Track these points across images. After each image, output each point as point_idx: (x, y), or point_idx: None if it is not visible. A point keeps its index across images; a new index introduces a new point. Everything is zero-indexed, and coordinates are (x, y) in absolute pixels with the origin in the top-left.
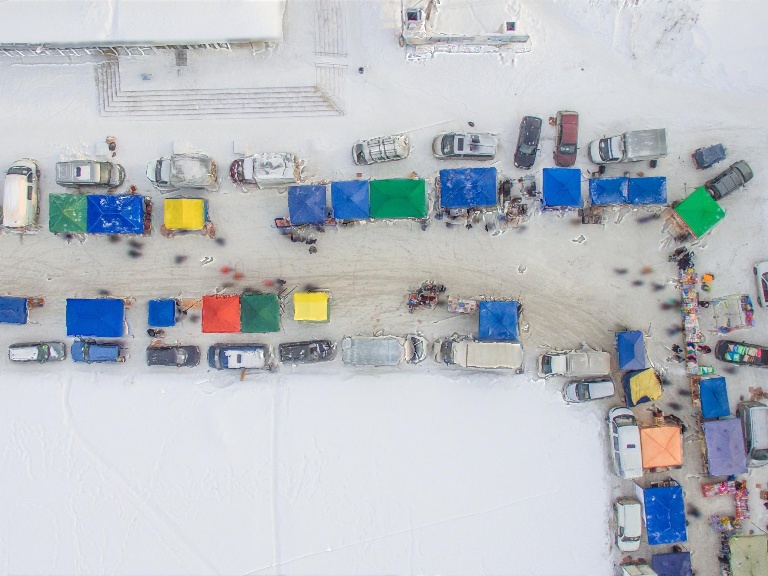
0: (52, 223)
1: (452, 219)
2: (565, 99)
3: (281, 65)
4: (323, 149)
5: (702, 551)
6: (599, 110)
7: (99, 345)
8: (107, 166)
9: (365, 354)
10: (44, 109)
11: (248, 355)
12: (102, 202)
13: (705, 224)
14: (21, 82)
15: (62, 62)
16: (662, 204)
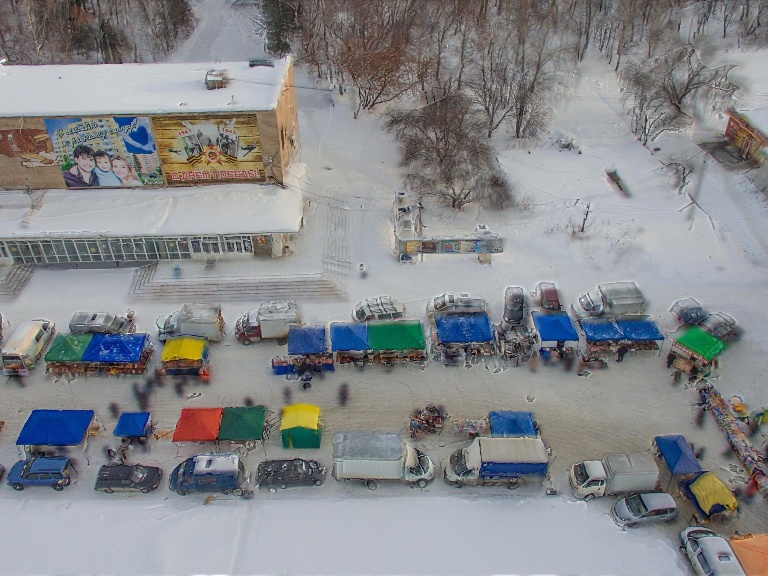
0: (50, 351)
1: (450, 359)
2: None
3: (294, 262)
4: (325, 315)
5: None
6: (573, 288)
7: (47, 458)
8: (121, 320)
9: (359, 448)
10: (81, 293)
11: (220, 460)
12: (107, 336)
13: (705, 344)
14: (70, 278)
15: (110, 267)
16: (656, 336)
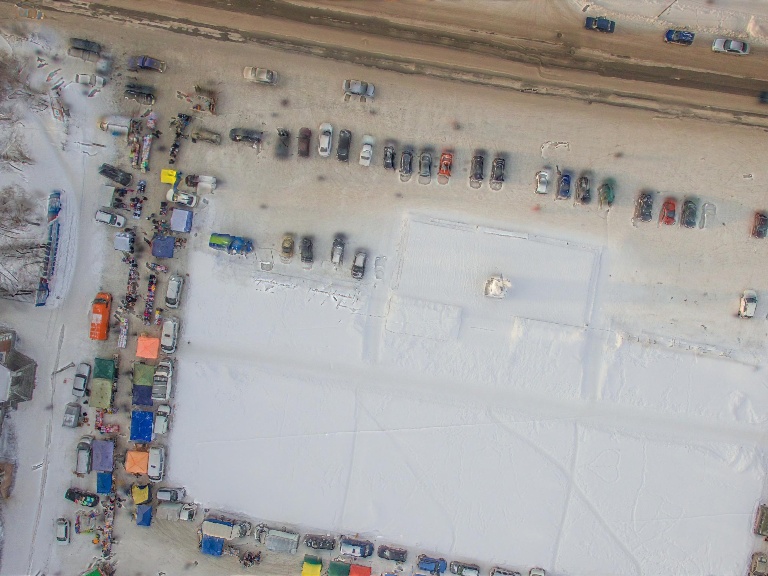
0: None
1: None
2: None
3: None
4: None
5: (126, 395)
6: None
7: (429, 570)
8: None
9: (286, 544)
10: None
11: (349, 552)
12: None
13: None
14: None
15: None
16: None
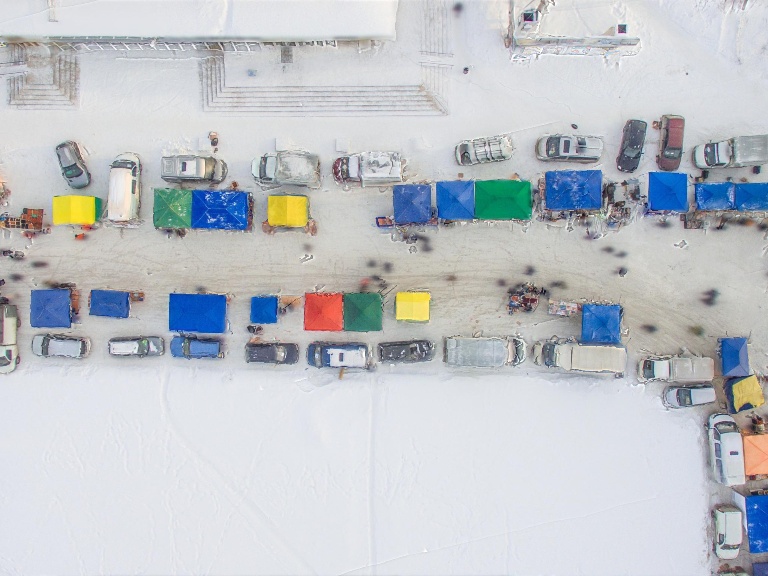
0: (157, 217)
1: (554, 221)
2: (669, 103)
3: (387, 64)
4: (425, 149)
5: None
6: (703, 115)
7: (200, 341)
8: (211, 161)
9: (470, 355)
10: (147, 103)
11: (350, 354)
12: (207, 197)
13: None
14: (125, 76)
15: (166, 57)
16: (767, 210)
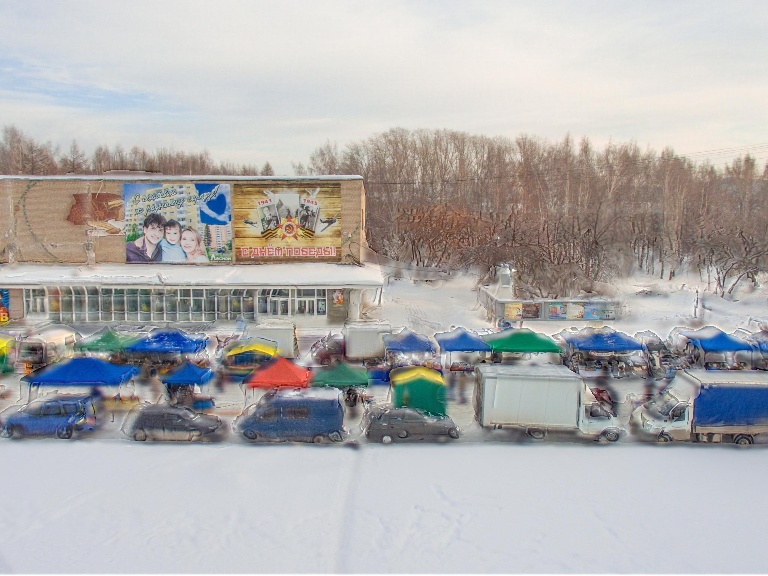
0: None
1: (592, 370)
2: None
3: None
4: None
5: None
6: None
7: None
8: None
9: None
10: None
11: (313, 388)
12: None
13: None
14: None
15: None
16: None
